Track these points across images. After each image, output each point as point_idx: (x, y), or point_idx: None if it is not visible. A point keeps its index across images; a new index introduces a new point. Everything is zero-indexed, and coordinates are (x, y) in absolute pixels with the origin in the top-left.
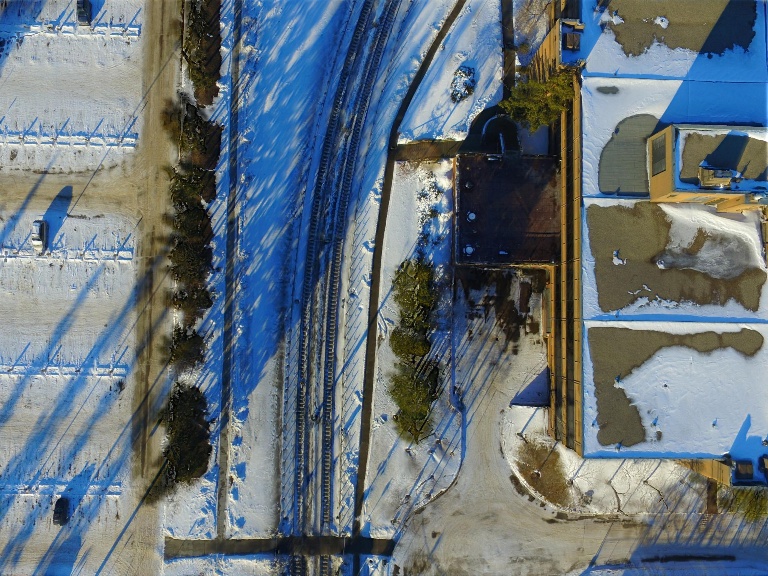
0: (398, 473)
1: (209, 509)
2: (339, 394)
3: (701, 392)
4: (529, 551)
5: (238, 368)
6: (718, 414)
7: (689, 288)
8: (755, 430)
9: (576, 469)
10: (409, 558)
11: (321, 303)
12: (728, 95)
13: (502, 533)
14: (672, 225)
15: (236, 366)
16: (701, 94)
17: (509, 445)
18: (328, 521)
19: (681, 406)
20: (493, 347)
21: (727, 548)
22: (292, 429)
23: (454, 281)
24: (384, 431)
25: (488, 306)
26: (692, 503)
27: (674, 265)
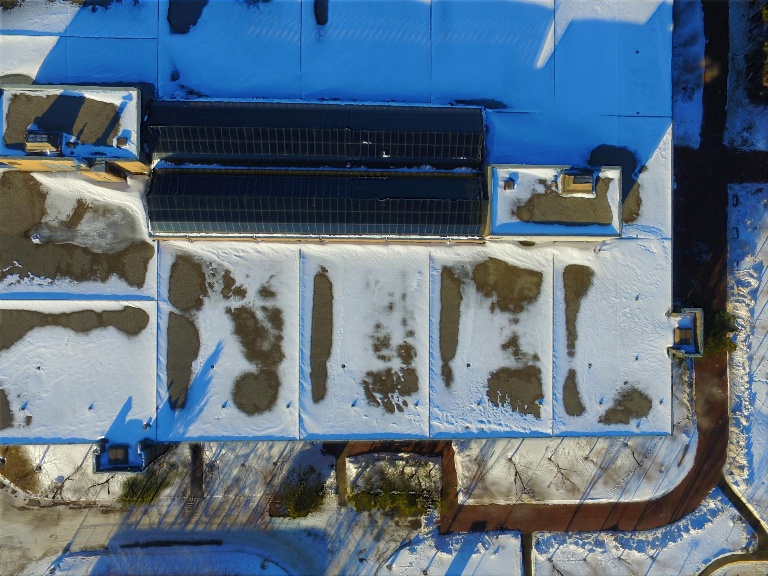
0: None
1: None
2: None
3: (79, 374)
4: None
5: None
6: (96, 397)
7: (66, 264)
8: (136, 413)
9: (41, 455)
10: None
11: None
12: (112, 52)
13: None
14: (48, 196)
15: None
16: (81, 51)
17: None
18: None
19: (55, 389)
20: None
21: (213, 532)
22: None
23: None
24: None
25: None
26: (175, 487)
27: (51, 239)
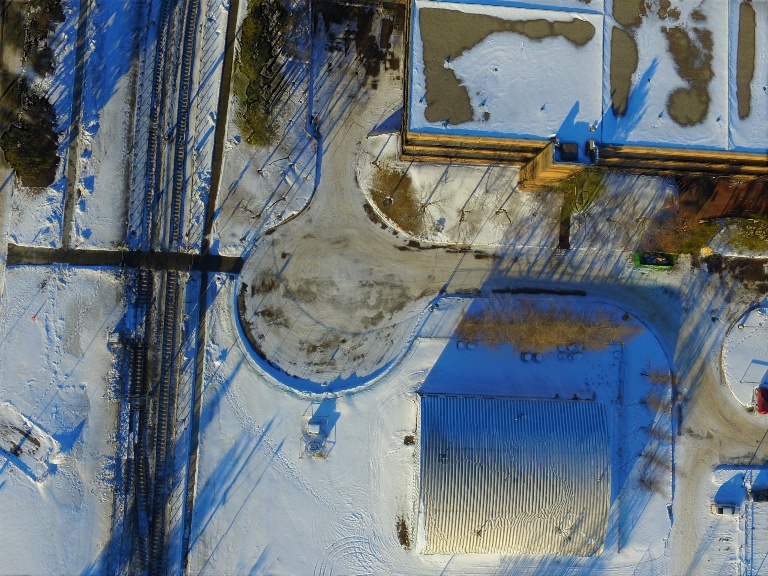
0: (249, 193)
1: (54, 218)
2: (193, 116)
3: (531, 78)
4: (379, 276)
5: (90, 83)
6: (547, 99)
7: None
8: (583, 116)
9: (428, 195)
10: (257, 277)
11: (178, 26)
12: None
13: (353, 257)
14: None
15: (88, 81)
16: None
17: (364, 174)
18: (177, 239)
19: (511, 90)
20: (352, 80)
21: (578, 283)
22: (144, 147)
23: (315, 14)
24: (237, 152)
25: (349, 40)
26: (544, 237)
27: None
